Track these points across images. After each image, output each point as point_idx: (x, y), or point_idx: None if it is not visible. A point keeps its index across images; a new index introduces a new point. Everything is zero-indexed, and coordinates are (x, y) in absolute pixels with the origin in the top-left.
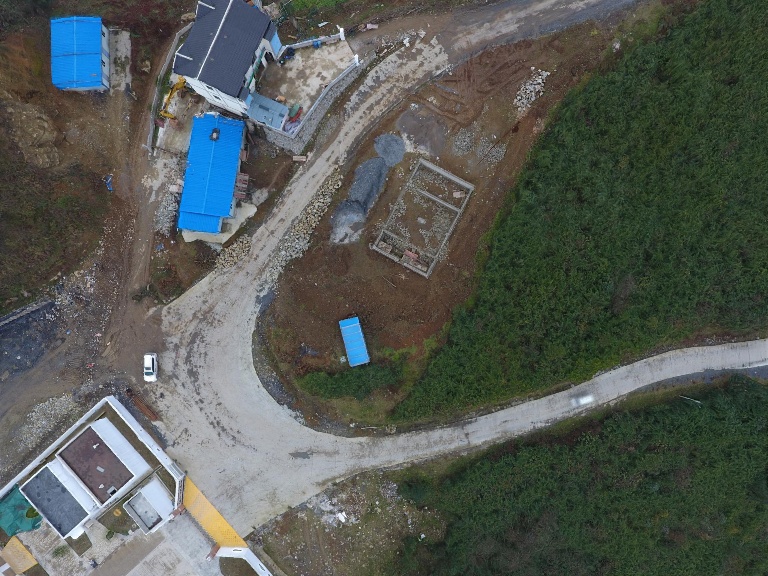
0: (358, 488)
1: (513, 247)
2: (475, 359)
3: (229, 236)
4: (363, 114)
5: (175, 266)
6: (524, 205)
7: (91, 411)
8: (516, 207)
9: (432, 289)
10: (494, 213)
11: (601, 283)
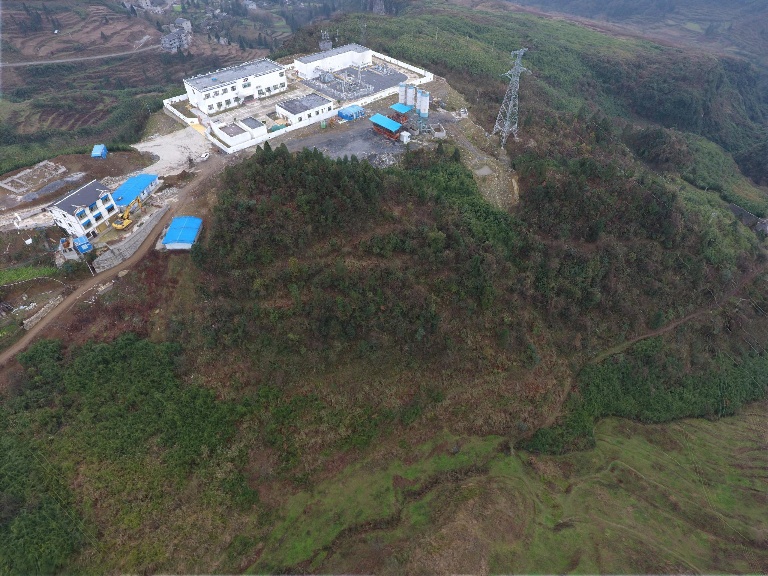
0: None
1: None
2: None
3: None
4: None
5: None
6: None
7: (236, 146)
8: None
9: None
10: None
11: None
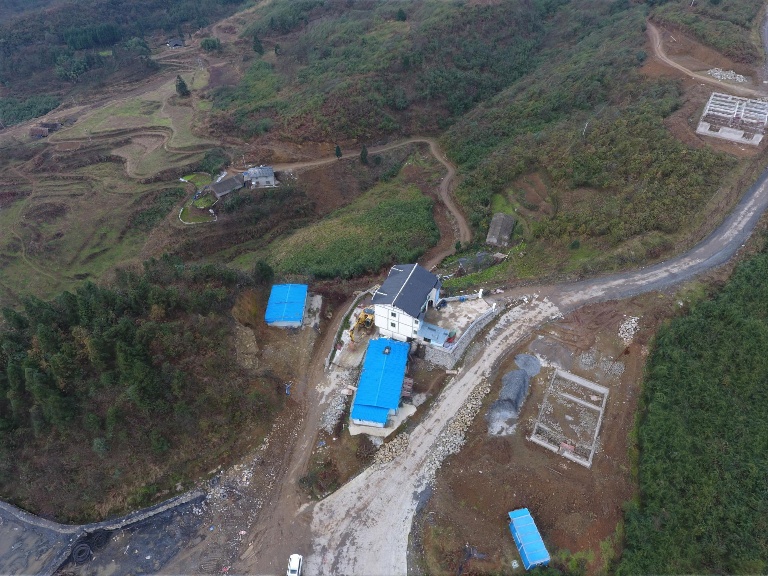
0: None
1: (663, 441)
2: (663, 572)
3: (391, 431)
4: (501, 342)
5: (336, 459)
6: (658, 404)
7: None
8: (652, 406)
9: (597, 480)
10: (632, 414)
11: (759, 492)
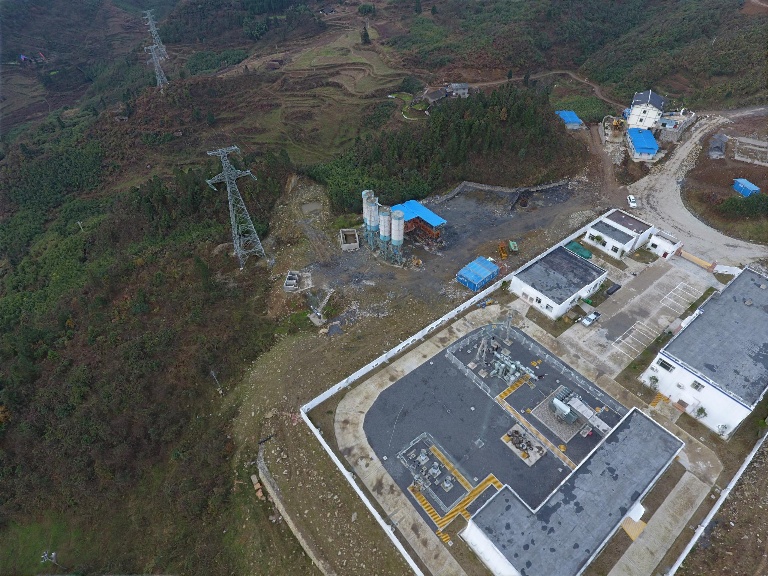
0: None
1: None
2: None
3: (656, 161)
4: None
5: None
6: None
7: (608, 212)
8: None
9: None
10: None
11: None
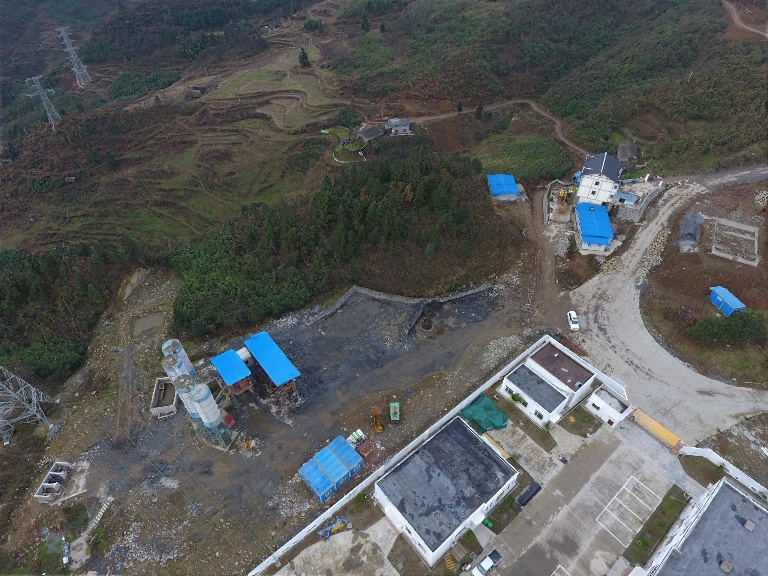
0: (767, 428)
1: None
2: None
3: (610, 253)
4: (669, 207)
5: (575, 269)
6: None
7: (538, 342)
8: None
9: (763, 273)
10: None
11: None
